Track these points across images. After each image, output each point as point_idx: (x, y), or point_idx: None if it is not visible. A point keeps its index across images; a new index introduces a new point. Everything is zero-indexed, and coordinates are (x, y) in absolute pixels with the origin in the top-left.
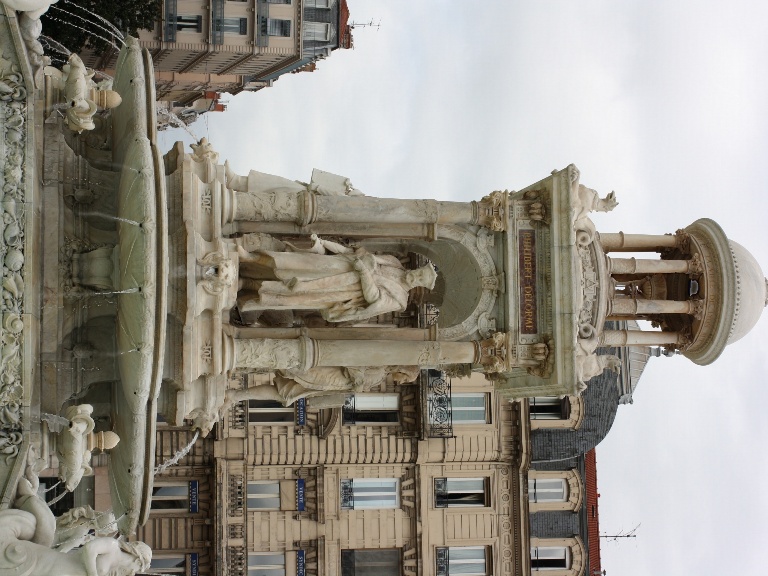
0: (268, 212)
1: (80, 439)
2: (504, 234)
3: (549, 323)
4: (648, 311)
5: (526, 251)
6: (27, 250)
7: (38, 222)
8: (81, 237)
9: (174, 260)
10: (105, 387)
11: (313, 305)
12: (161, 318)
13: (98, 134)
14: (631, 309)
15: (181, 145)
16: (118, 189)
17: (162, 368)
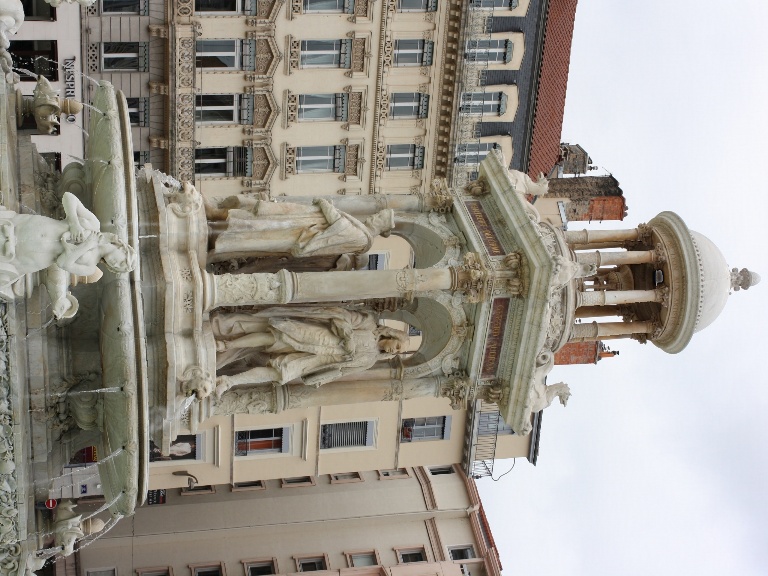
0: None
1: None
2: (453, 211)
3: (514, 244)
4: (612, 258)
5: (476, 212)
6: (1, 115)
7: None
8: None
9: (143, 197)
10: (93, 342)
11: (282, 238)
12: (127, 142)
13: None
14: (595, 256)
15: None
16: None
17: (136, 199)
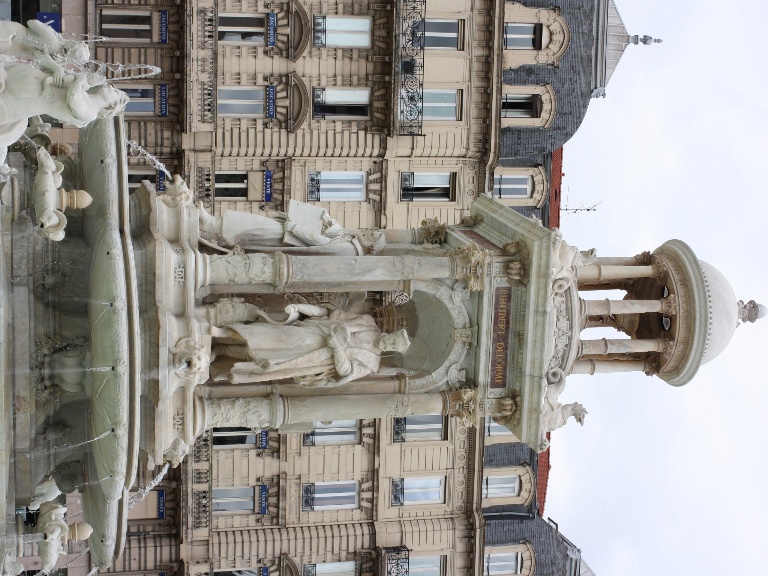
0: (242, 279)
1: (54, 542)
2: None
3: (518, 379)
4: (618, 352)
5: (501, 308)
6: None
7: (8, 337)
8: (52, 336)
9: (146, 348)
10: None
11: None
12: (134, 448)
13: (67, 180)
14: (601, 351)
15: (154, 198)
16: (89, 269)
17: None
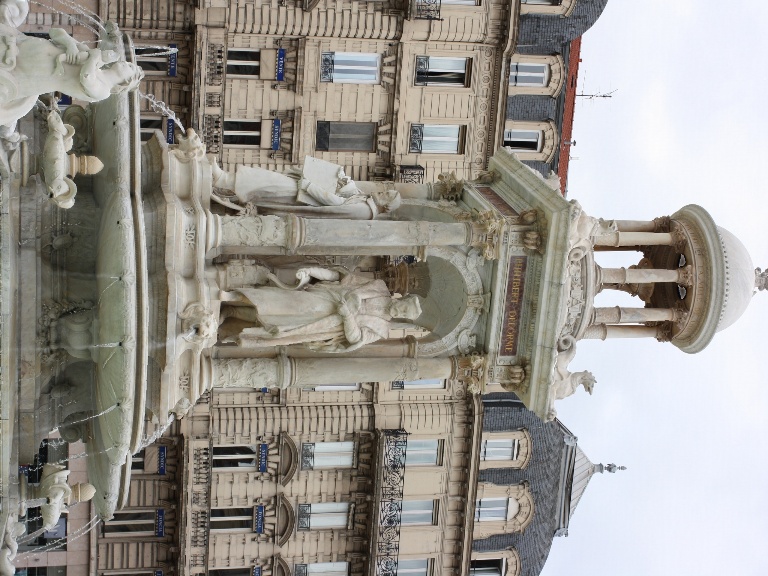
0: (254, 242)
1: (57, 504)
2: None
3: (529, 348)
4: None
5: (516, 277)
6: (4, 360)
7: (15, 303)
8: (59, 299)
9: (154, 313)
10: None
11: None
12: (139, 421)
13: (78, 132)
14: (614, 320)
15: (166, 154)
16: (98, 230)
17: None
